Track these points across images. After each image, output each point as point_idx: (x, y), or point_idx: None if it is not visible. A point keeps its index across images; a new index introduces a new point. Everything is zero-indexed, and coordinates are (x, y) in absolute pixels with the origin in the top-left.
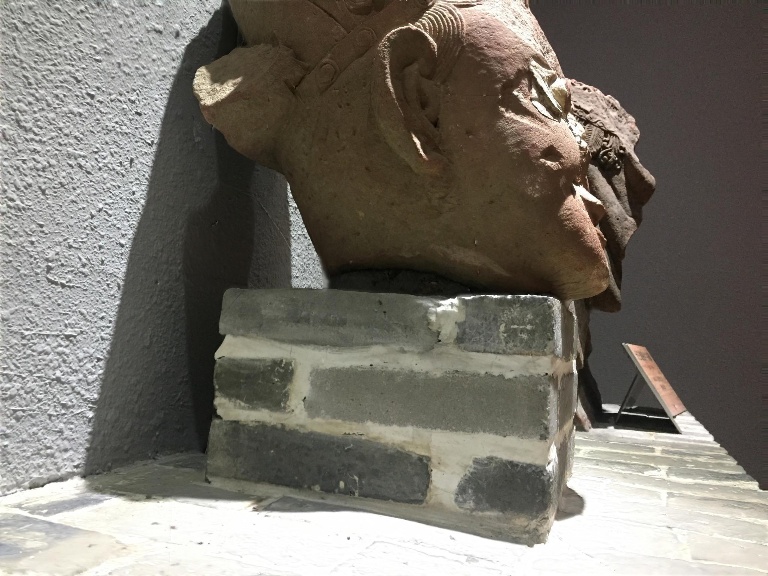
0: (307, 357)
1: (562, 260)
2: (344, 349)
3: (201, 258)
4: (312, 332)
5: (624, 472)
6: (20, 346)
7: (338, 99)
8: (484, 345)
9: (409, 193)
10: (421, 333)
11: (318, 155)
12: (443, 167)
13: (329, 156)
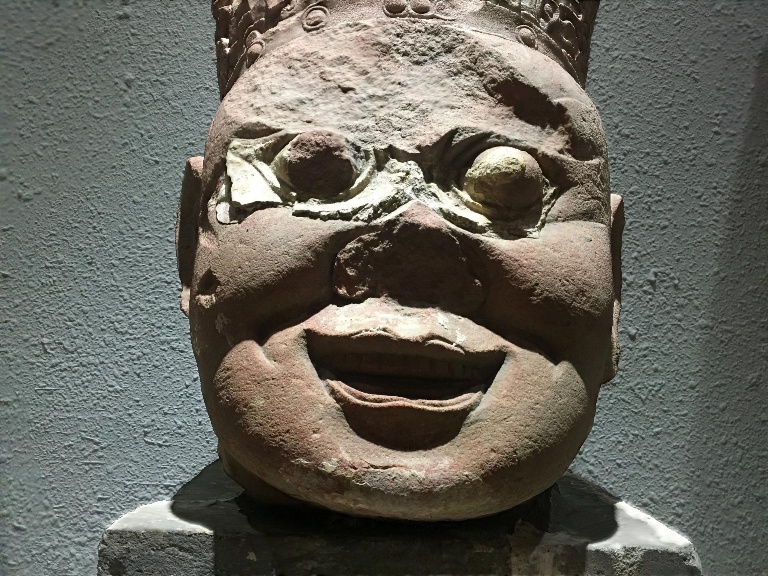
0: None
1: None
2: None
3: None
4: None
5: None
6: (124, 493)
7: None
8: None
9: None
10: None
11: None
12: None
13: None
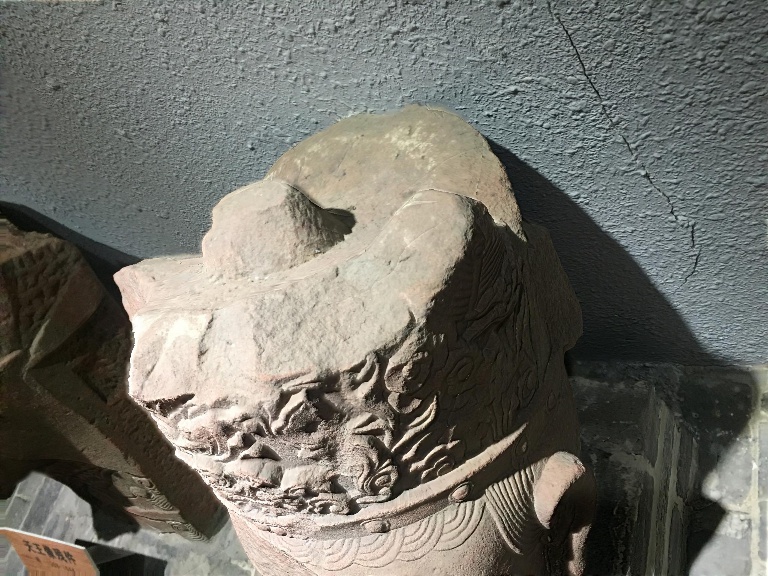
0: None
1: None
2: None
3: None
4: None
5: None
6: None
7: None
8: None
9: None
10: None
11: None
12: None
13: None
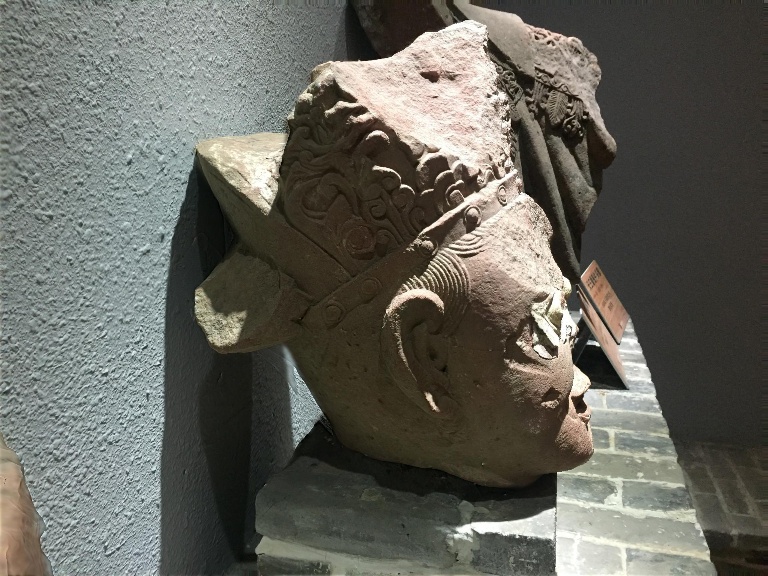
0: (341, 562)
1: (557, 469)
2: (374, 560)
3: (214, 417)
4: (344, 544)
5: (589, 507)
6: None
7: (347, 338)
8: (496, 570)
9: (421, 426)
10: (441, 554)
11: (329, 374)
12: (453, 413)
13: (340, 379)
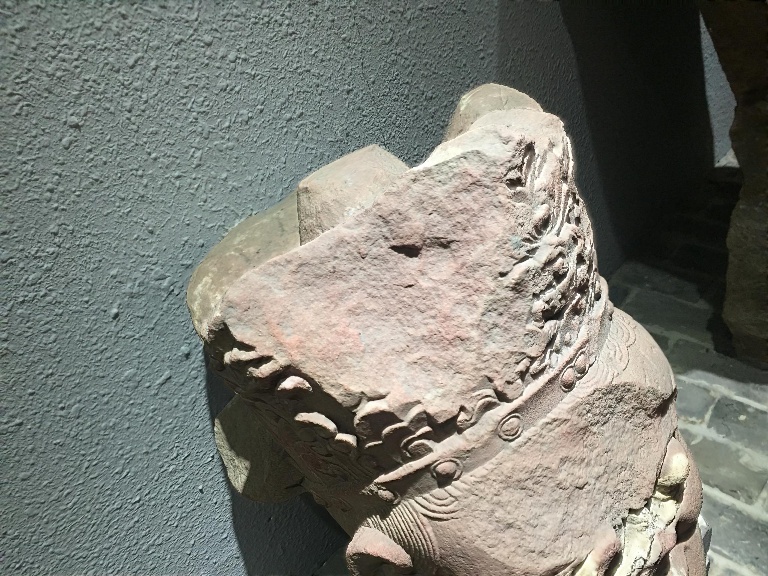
0: None
1: None
2: None
3: None
4: None
5: None
6: None
7: None
8: None
9: None
10: None
11: None
12: None
13: None
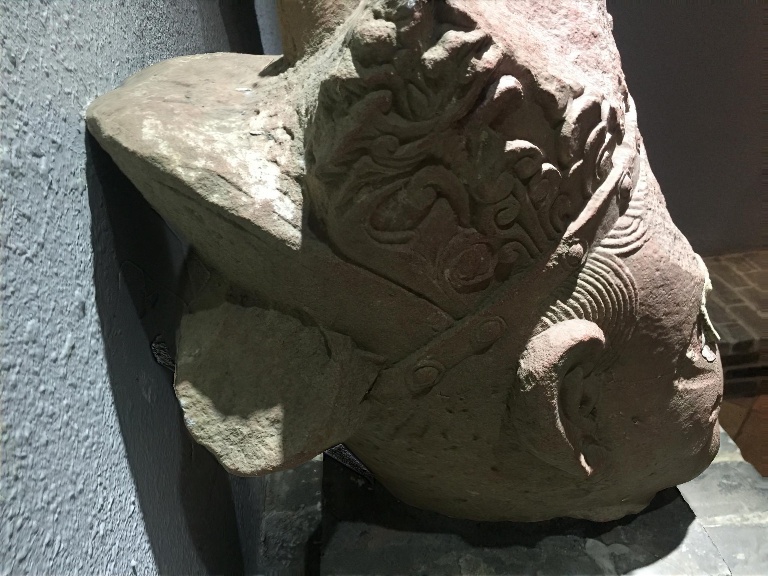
0: None
1: None
2: None
3: (199, 508)
4: None
5: None
6: None
7: (447, 405)
8: None
9: (552, 484)
10: None
11: (406, 446)
12: None
13: (427, 451)
